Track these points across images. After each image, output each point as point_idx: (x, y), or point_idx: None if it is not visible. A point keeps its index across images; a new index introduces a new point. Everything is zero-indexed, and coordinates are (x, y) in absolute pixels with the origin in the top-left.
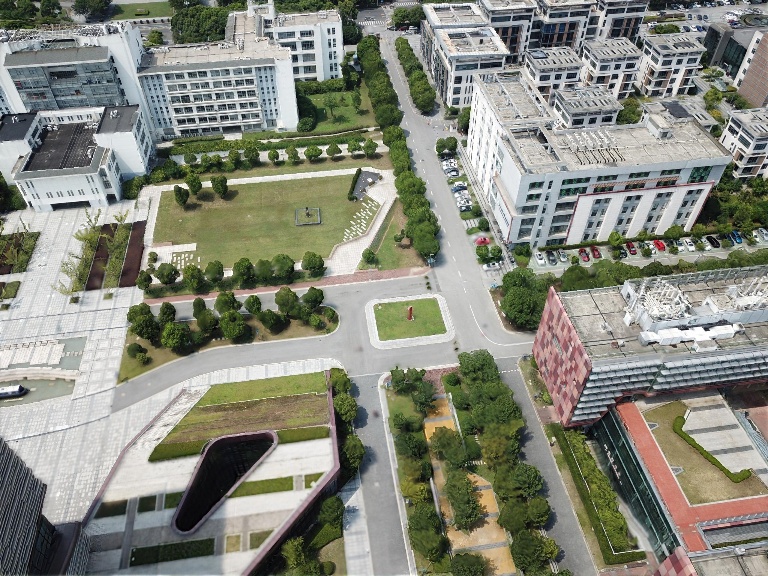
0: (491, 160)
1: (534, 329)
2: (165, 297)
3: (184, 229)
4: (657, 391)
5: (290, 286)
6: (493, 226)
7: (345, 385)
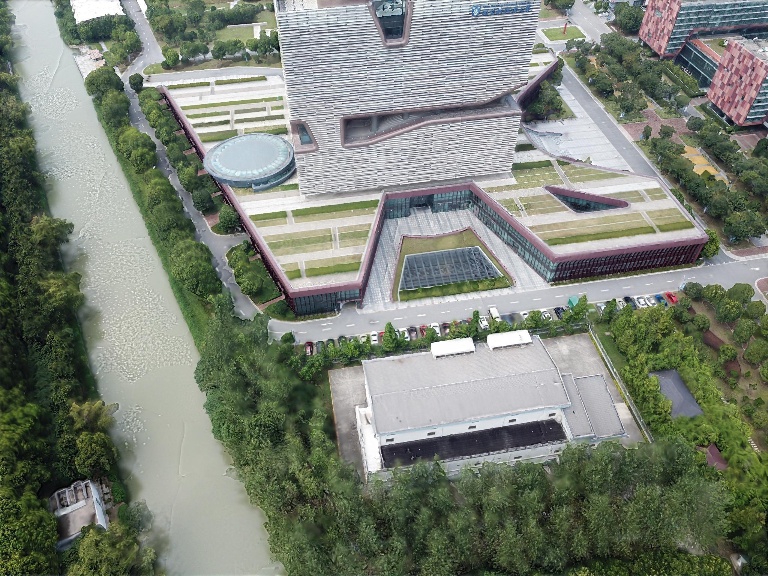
0: None
1: (634, 35)
2: None
3: None
4: (710, 27)
5: None
6: (599, 0)
7: None
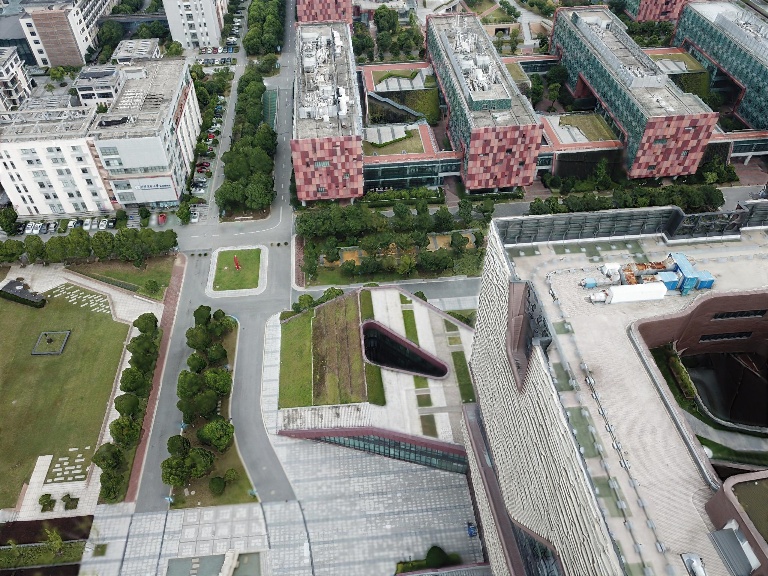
0: (82, 178)
1: (269, 205)
2: (130, 476)
3: (0, 474)
4: None
5: (161, 354)
6: None
7: None
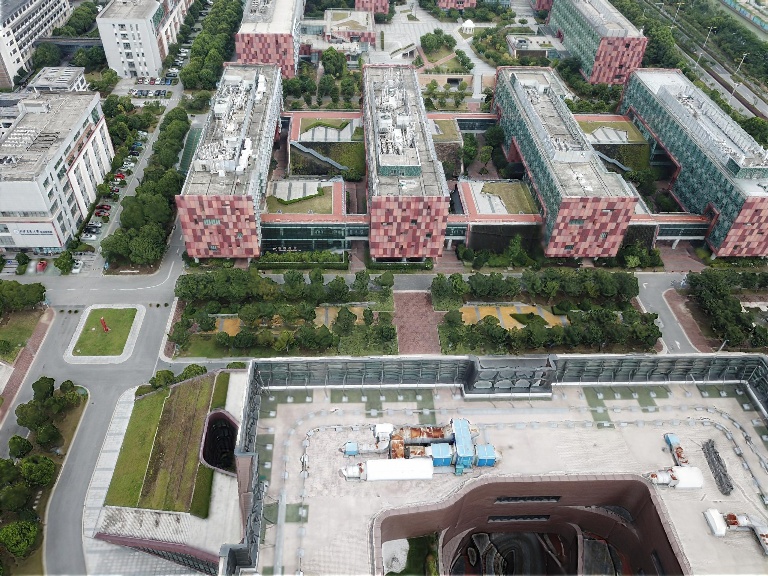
0: None
1: (161, 259)
2: None
3: None
4: (263, 196)
5: None
6: None
7: (169, 374)
